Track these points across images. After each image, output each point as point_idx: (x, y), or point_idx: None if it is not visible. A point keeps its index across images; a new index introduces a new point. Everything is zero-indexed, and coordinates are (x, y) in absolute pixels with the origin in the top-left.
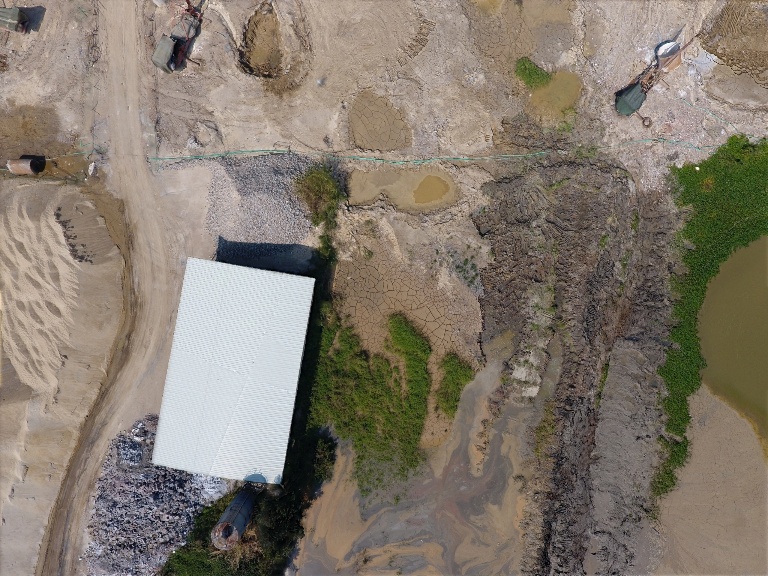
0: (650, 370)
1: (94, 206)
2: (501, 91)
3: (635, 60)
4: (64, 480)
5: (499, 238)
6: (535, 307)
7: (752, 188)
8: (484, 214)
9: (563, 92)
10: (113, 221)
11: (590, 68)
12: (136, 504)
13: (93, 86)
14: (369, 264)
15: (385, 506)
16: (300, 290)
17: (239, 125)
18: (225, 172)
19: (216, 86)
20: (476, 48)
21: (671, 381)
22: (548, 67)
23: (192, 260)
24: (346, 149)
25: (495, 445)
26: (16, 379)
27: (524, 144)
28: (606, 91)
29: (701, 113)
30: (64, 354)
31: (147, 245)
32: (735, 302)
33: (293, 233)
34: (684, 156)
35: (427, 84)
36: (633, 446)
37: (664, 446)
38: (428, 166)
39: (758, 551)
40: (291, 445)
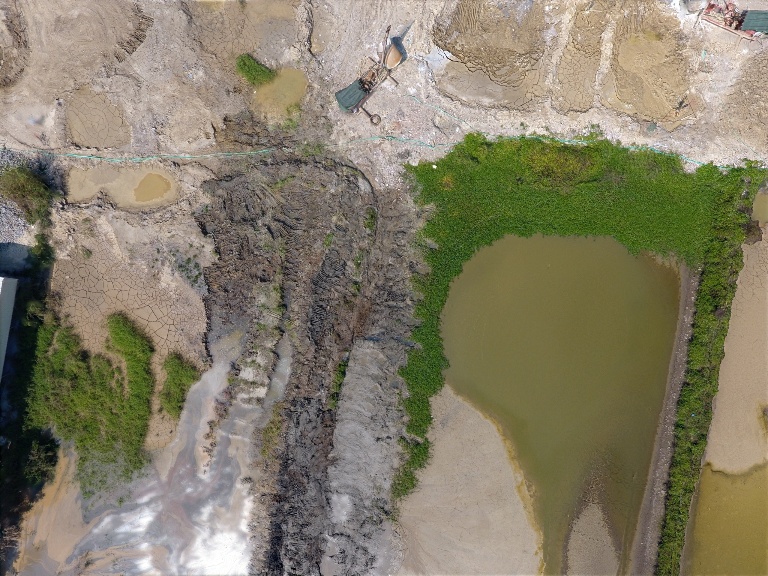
0: (391, 371)
1: None
2: (222, 88)
3: (363, 57)
4: None
5: (224, 237)
6: (260, 307)
7: (494, 187)
8: (208, 213)
9: (289, 89)
10: None
11: (316, 65)
12: None
13: None
14: (88, 263)
15: (108, 508)
16: None
17: None
18: None
19: None
20: (196, 44)
21: (412, 382)
22: (271, 64)
23: None
24: (62, 146)
25: (222, 446)
26: None
27: (248, 142)
28: (334, 88)
29: (431, 110)
30: None
31: None
32: (479, 302)
33: (5, 232)
34: (417, 154)
35: (146, 81)
36: (373, 447)
37: (404, 447)
38: (148, 164)
39: (502, 553)
40: (6, 447)
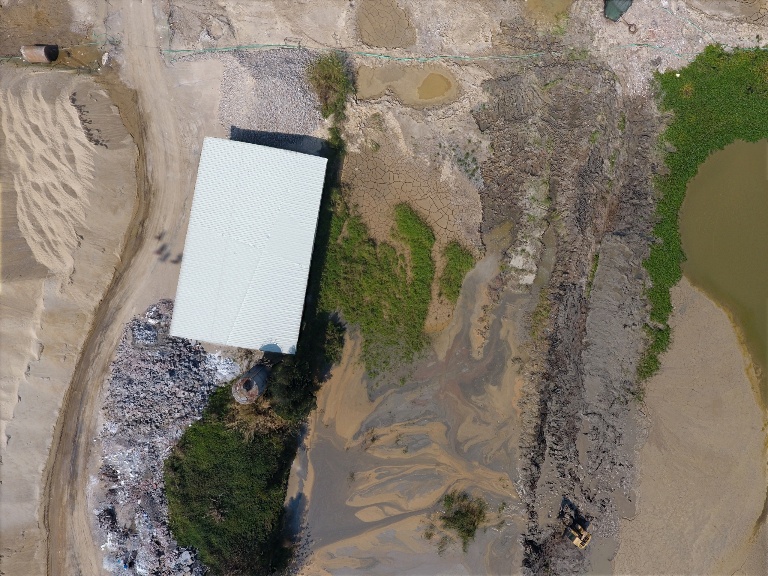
0: (636, 263)
1: (108, 95)
2: None
3: None
4: (78, 363)
5: (498, 134)
6: (531, 199)
7: (726, 95)
8: (484, 111)
9: None
10: (126, 110)
11: None
12: (152, 380)
13: None
14: (376, 156)
15: (392, 388)
16: (313, 169)
17: (250, 20)
18: (238, 62)
19: None
20: None
21: (655, 273)
22: None
23: (208, 139)
24: (354, 45)
25: (495, 330)
26: (32, 258)
27: (520, 46)
28: None
29: (681, 22)
30: (80, 234)
31: (160, 134)
32: (712, 201)
33: (303, 124)
34: (666, 62)
35: None
36: (621, 334)
37: (649, 333)
38: (431, 64)
39: (733, 430)
40: (302, 328)
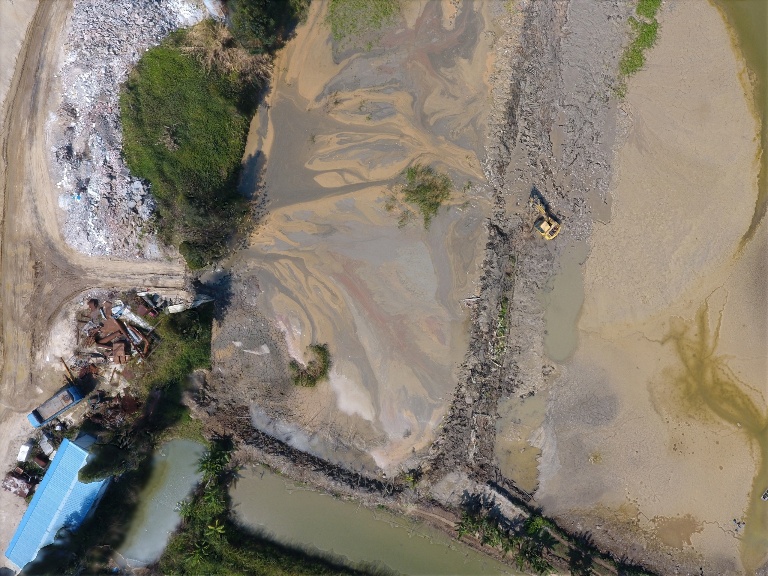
0: None
1: None
2: None
3: None
4: None
5: None
6: None
7: None
8: None
9: None
10: None
11: None
12: (112, 2)
13: None
14: None
15: (358, 51)
16: None
17: None
18: None
19: None
20: None
21: None
22: None
23: None
24: None
25: (468, 0)
26: None
27: None
28: None
29: None
30: None
31: None
32: None
33: None
34: None
35: None
36: (604, 24)
37: (634, 26)
38: None
39: (722, 137)
40: None
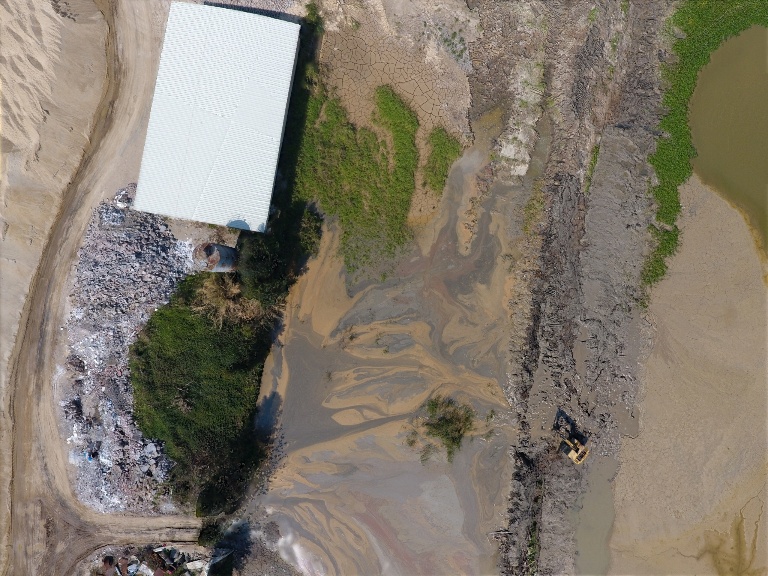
0: (640, 158)
1: None
2: None
3: None
4: (46, 248)
5: (488, 13)
6: (524, 83)
7: None
8: None
9: None
10: None
11: None
12: (118, 262)
13: None
14: (356, 35)
15: (372, 283)
16: (285, 35)
17: None
18: None
19: None
20: None
21: (662, 169)
22: None
23: (176, 4)
24: None
25: (483, 224)
26: None
27: None
28: None
29: None
30: (46, 109)
31: (131, 12)
32: (726, 92)
33: None
34: None
35: None
36: (623, 234)
37: (654, 234)
38: None
39: (749, 343)
40: (276, 215)
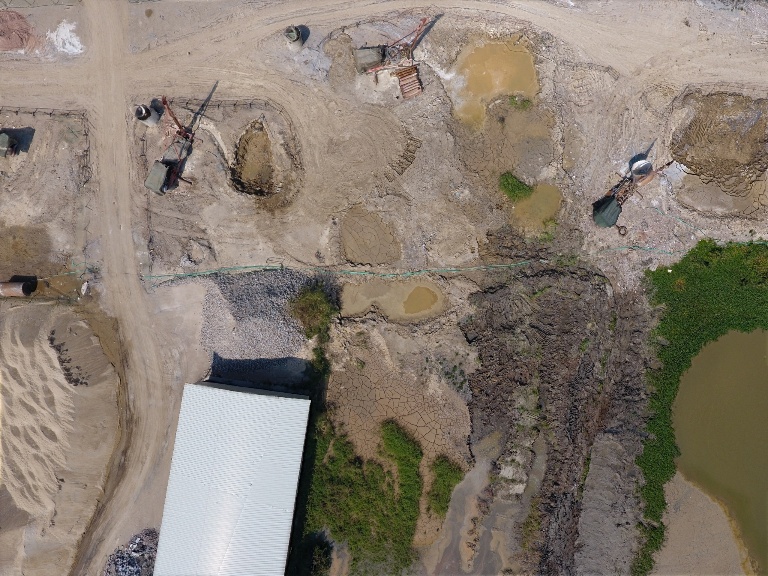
0: (629, 461)
1: (88, 325)
2: (485, 205)
3: (611, 172)
4: None
5: (486, 344)
6: (521, 409)
7: (720, 287)
8: (471, 322)
9: (544, 204)
10: (107, 339)
11: (569, 181)
12: None
13: (84, 206)
14: (361, 374)
15: None
16: (296, 412)
17: (232, 242)
18: (219, 291)
19: (208, 204)
20: (461, 164)
21: (648, 470)
22: (530, 181)
23: (189, 386)
24: (337, 264)
25: (485, 541)
26: (12, 505)
27: (508, 254)
28: (584, 202)
29: (672, 221)
30: (61, 478)
31: (142, 362)
32: (706, 393)
33: (287, 347)
34: (657, 261)
35: (415, 199)
36: (614, 533)
37: (643, 532)
38: (417, 278)
39: None
40: None
